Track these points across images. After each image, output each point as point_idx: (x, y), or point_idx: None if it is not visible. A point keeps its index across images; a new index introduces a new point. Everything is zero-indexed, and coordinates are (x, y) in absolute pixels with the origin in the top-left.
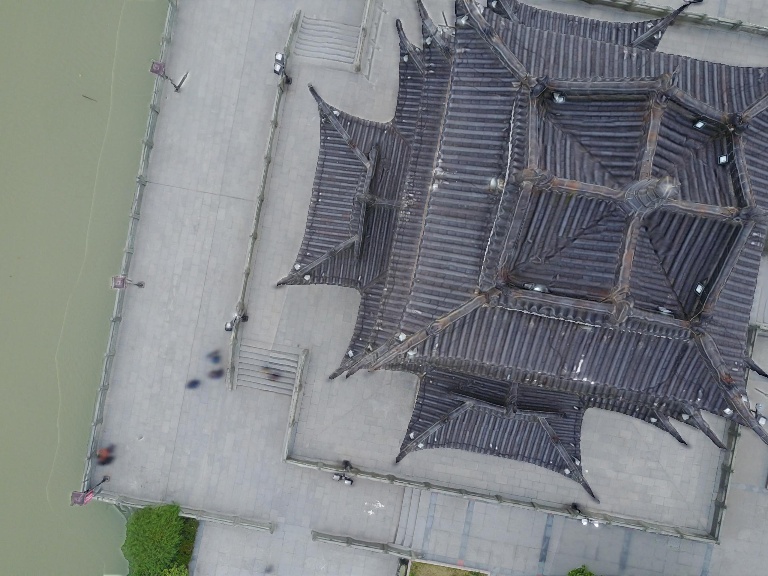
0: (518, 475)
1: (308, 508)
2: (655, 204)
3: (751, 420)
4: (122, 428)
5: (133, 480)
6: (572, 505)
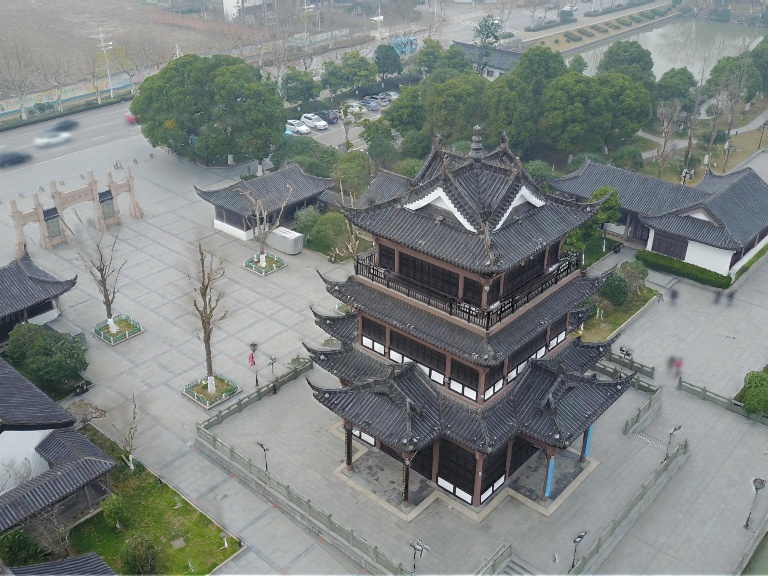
0: None
1: None
2: None
3: None
4: None
5: None
6: None
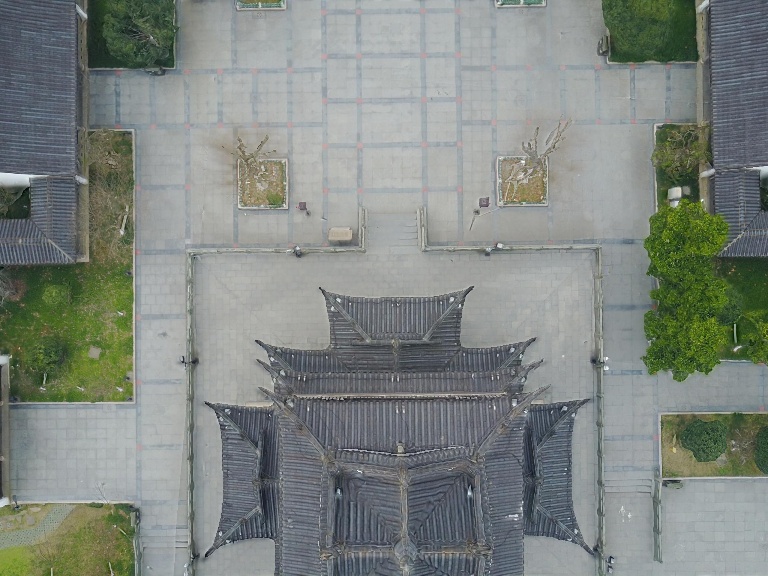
0: (578, 411)
1: (637, 567)
2: (414, 555)
3: (530, 400)
4: None
5: None
6: (593, 364)
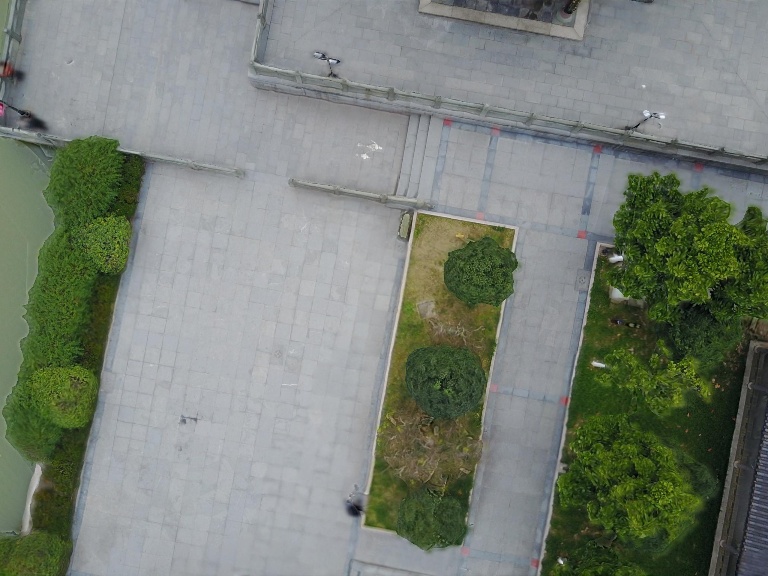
0: (555, 92)
1: (284, 151)
2: None
3: None
4: (46, 49)
5: (60, 116)
6: (625, 129)
